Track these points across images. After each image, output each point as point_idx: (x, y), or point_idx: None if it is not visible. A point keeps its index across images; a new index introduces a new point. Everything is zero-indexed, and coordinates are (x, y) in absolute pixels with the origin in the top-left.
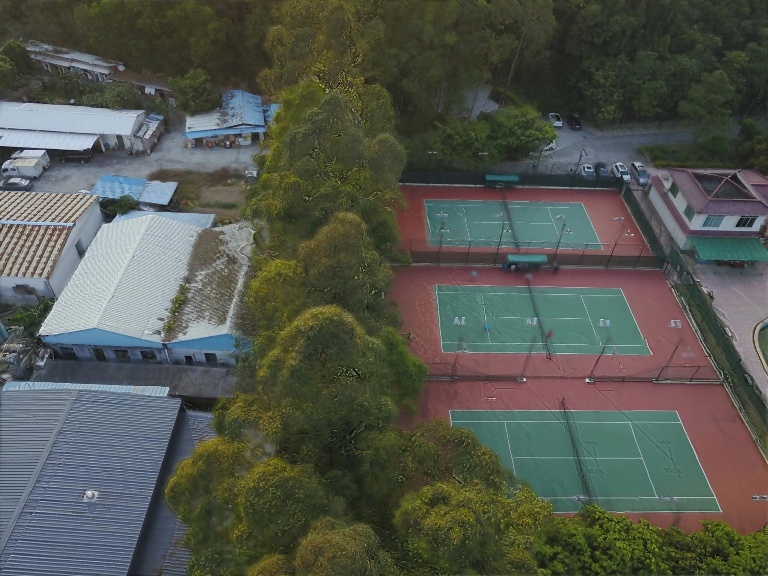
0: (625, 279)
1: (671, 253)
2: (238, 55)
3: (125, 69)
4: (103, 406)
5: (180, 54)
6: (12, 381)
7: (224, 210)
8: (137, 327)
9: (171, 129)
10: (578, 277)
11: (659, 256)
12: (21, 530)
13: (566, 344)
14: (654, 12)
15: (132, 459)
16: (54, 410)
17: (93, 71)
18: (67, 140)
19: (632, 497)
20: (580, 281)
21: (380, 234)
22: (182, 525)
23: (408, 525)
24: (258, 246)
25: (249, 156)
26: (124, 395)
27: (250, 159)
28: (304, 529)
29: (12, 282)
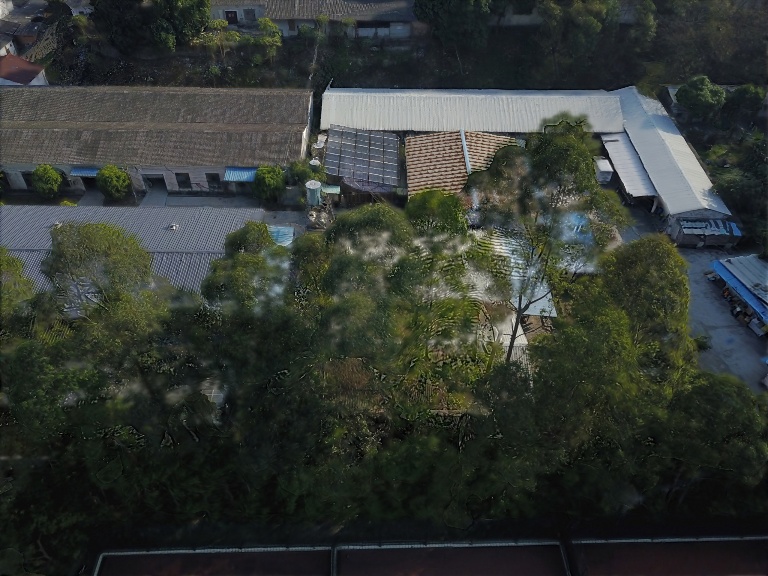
0: None
1: None
2: None
3: None
4: None
5: None
6: (294, 229)
7: None
8: None
9: (738, 253)
10: None
11: None
12: None
13: None
14: None
15: None
16: None
17: None
18: (637, 178)
19: None
20: None
21: None
22: None
23: None
24: None
25: (729, 339)
26: None
27: (722, 341)
28: None
29: None
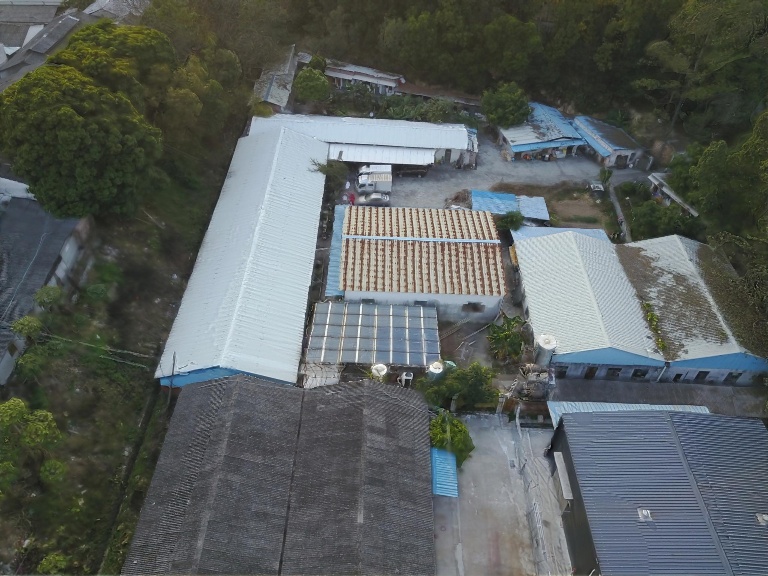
0: None
1: None
2: (537, 68)
3: (405, 82)
4: (701, 427)
5: (479, 67)
6: (552, 401)
7: (588, 224)
8: (639, 346)
9: None
10: None
11: None
12: (733, 554)
13: None
14: None
15: None
16: (660, 432)
17: (377, 84)
18: (407, 155)
19: None
20: None
21: None
22: None
23: None
24: None
25: (571, 169)
26: (710, 416)
27: (575, 172)
28: None
29: (466, 300)
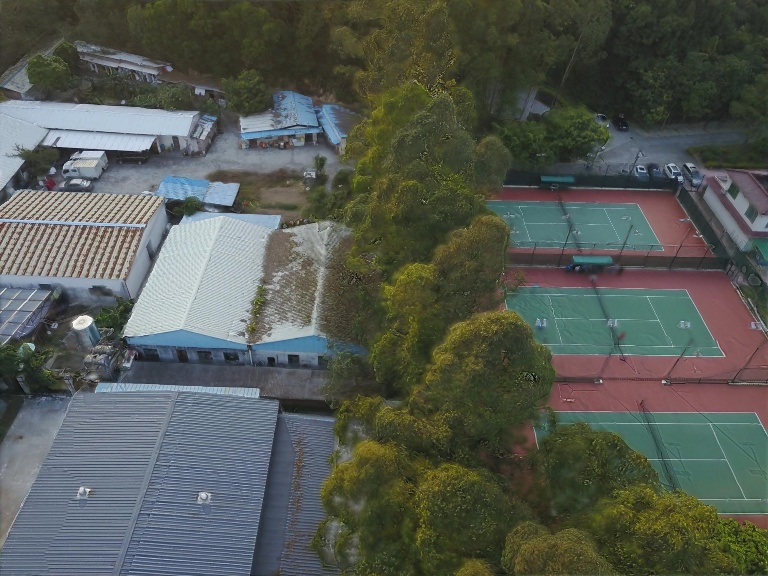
0: (689, 280)
1: (736, 254)
2: (289, 56)
3: (173, 70)
4: (204, 408)
5: (231, 55)
6: (103, 382)
7: (286, 211)
8: (222, 329)
9: (223, 130)
10: (642, 278)
11: (723, 257)
12: (141, 532)
13: (638, 345)
14: (703, 13)
15: (239, 461)
16: (157, 412)
17: (141, 72)
18: (125, 141)
19: (721, 499)
20: (645, 282)
21: None
22: (292, 527)
23: (615, 529)
24: (356, 248)
25: (304, 157)
26: (223, 397)
27: (305, 160)
28: (500, 533)
29: (89, 283)
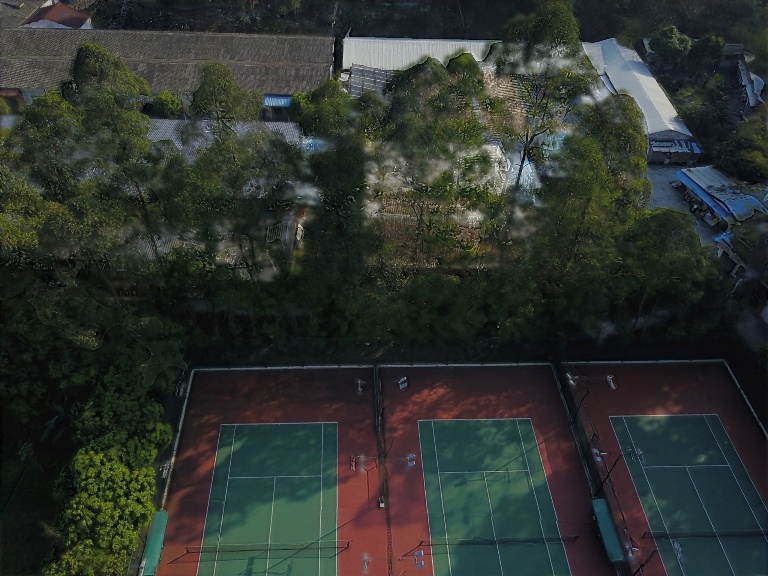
0: None
1: None
2: None
3: None
4: None
5: None
6: None
7: None
8: None
9: None
10: None
11: None
12: None
13: (452, 574)
14: None
15: None
16: None
17: (749, 98)
18: None
19: None
20: None
21: (316, 163)
22: None
23: None
24: None
25: None
26: None
27: None
28: None
29: None
